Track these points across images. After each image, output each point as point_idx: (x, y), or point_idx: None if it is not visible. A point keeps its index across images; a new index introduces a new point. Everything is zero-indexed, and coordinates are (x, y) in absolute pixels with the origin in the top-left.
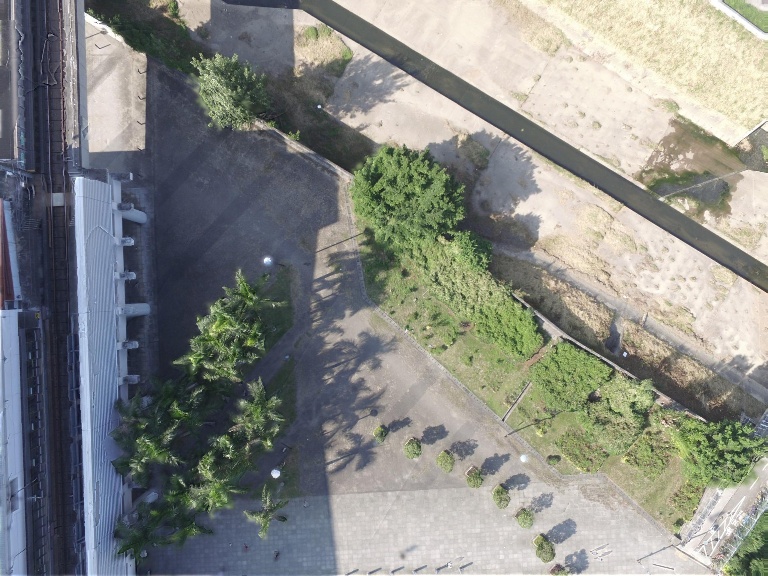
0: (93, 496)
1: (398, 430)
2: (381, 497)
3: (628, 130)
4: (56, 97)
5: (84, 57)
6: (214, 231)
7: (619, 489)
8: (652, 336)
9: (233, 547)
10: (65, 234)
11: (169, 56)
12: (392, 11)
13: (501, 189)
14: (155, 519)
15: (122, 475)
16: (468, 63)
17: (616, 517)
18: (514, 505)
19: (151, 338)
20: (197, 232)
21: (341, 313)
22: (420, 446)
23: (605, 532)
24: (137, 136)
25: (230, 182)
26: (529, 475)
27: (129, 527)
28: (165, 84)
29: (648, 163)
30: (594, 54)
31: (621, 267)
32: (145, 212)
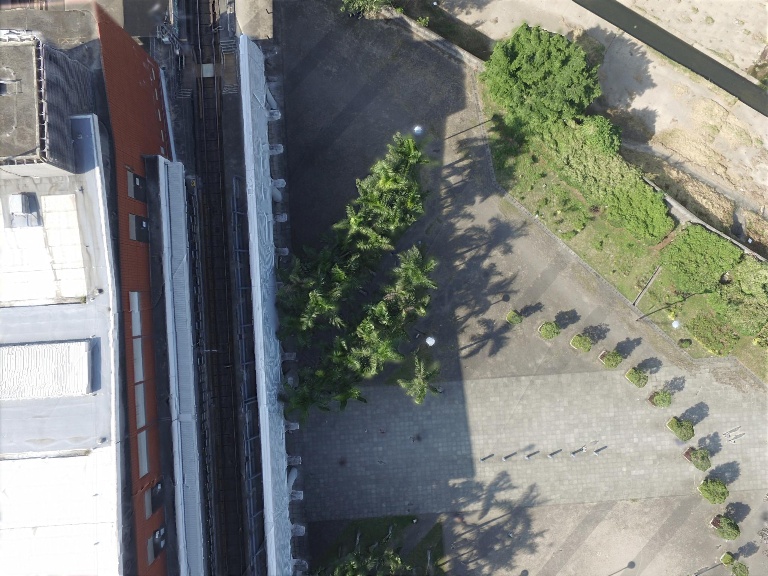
0: (264, 352)
1: (530, 315)
2: (515, 382)
3: (741, 25)
4: None
5: None
6: (344, 119)
7: (750, 372)
8: None
9: (369, 433)
10: (215, 105)
11: None
12: None
13: (617, 84)
14: (319, 381)
15: (279, 342)
16: None
17: (748, 400)
18: (647, 389)
19: (283, 225)
20: (327, 120)
21: (471, 199)
22: (558, 326)
23: (737, 415)
24: (265, 25)
25: (358, 70)
26: (661, 359)
27: (294, 388)
28: None
29: (761, 58)
30: None
31: (737, 160)
32: (275, 100)
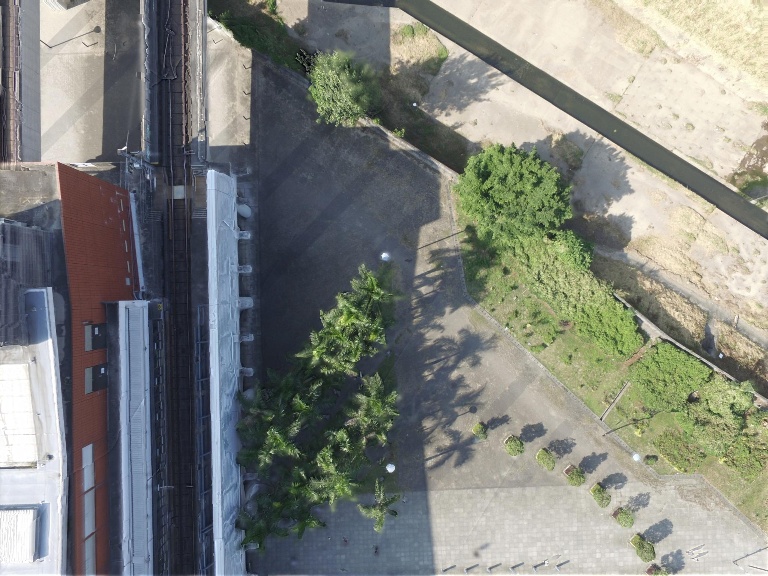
0: (221, 486)
1: (497, 427)
2: (479, 494)
3: (721, 132)
4: (177, 91)
5: (205, 51)
6: (317, 226)
7: (716, 490)
8: (745, 338)
9: (332, 541)
10: (185, 226)
11: (278, 52)
12: (488, 10)
13: (594, 189)
14: (277, 511)
15: (240, 466)
16: (563, 63)
17: (712, 518)
18: (611, 504)
19: (254, 331)
20: (300, 227)
21: (442, 310)
22: None
23: (701, 533)
24: (242, 131)
25: (333, 178)
26: (626, 474)
27: (252, 518)
28: (270, 80)
29: (741, 166)
30: (688, 56)
31: (713, 269)
32: (250, 206)
